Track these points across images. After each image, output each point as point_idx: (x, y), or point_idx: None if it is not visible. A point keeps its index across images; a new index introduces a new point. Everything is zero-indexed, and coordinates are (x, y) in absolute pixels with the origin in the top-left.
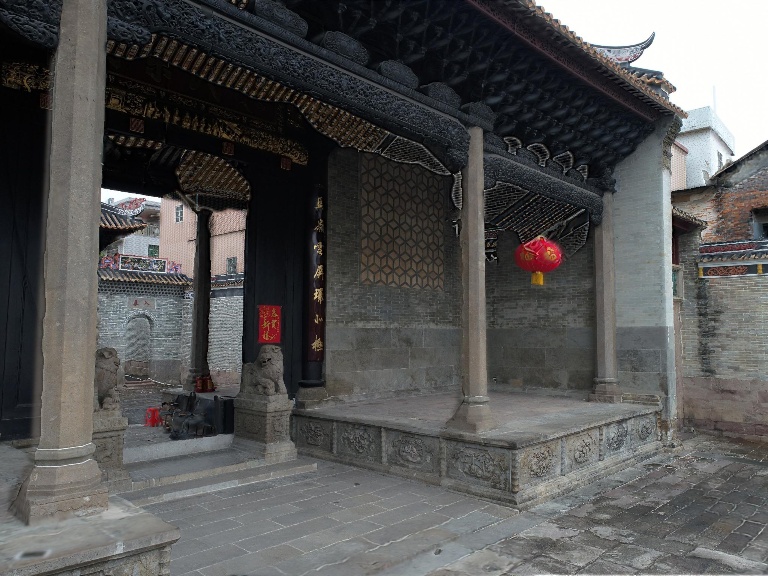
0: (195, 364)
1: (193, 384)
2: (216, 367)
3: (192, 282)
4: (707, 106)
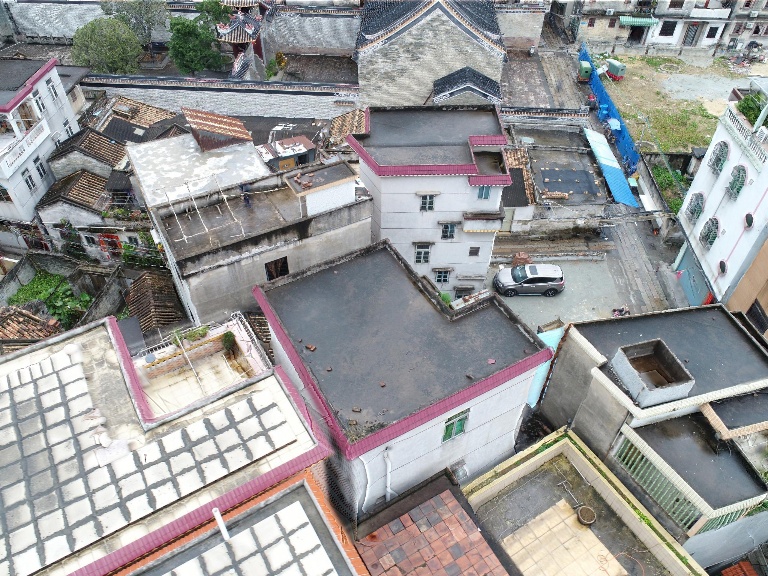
0: None
1: None
2: (308, 46)
3: (279, 7)
4: None
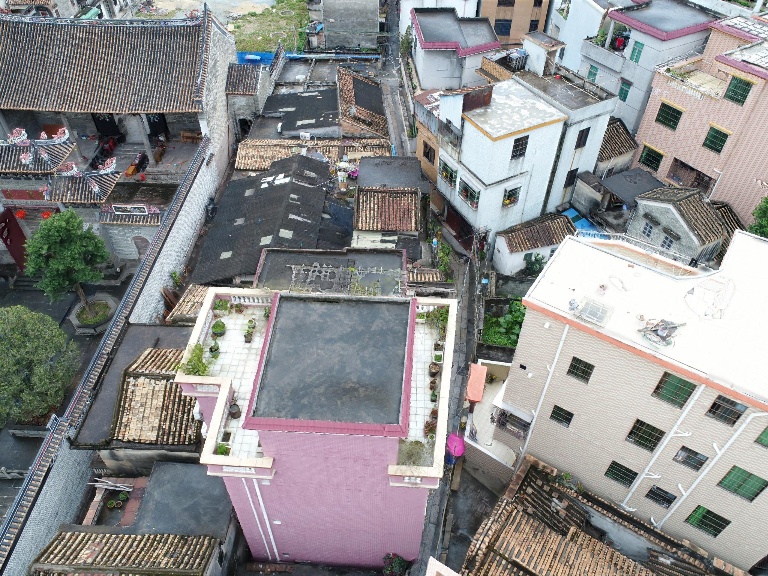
0: (82, 156)
1: (86, 160)
2: None
3: None
4: None
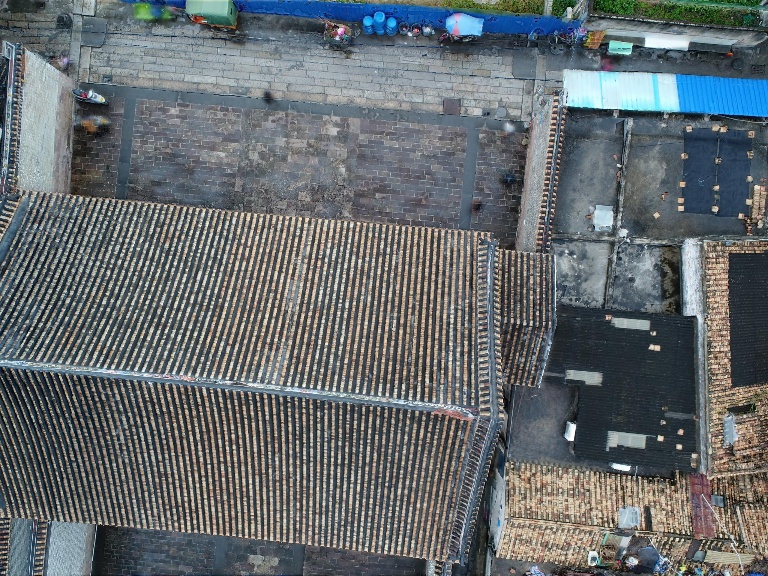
0: None
1: None
2: None
3: None
4: None
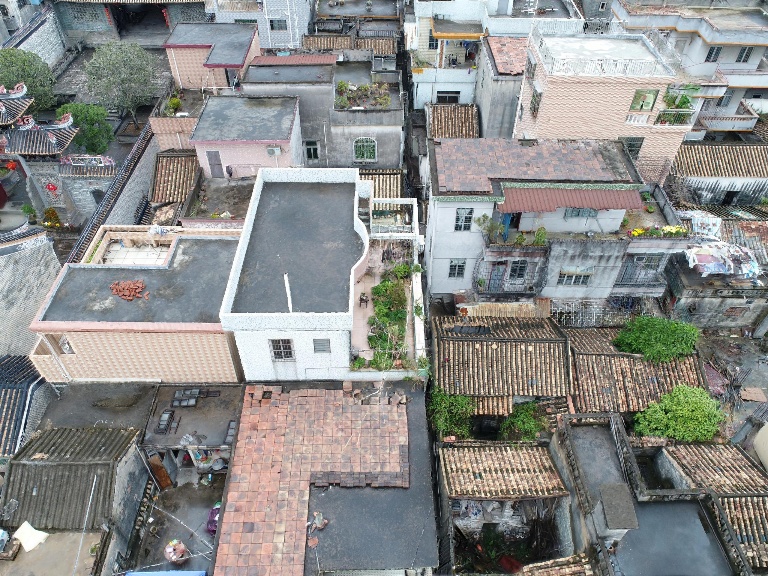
0: None
1: None
2: None
3: None
4: (219, 315)
